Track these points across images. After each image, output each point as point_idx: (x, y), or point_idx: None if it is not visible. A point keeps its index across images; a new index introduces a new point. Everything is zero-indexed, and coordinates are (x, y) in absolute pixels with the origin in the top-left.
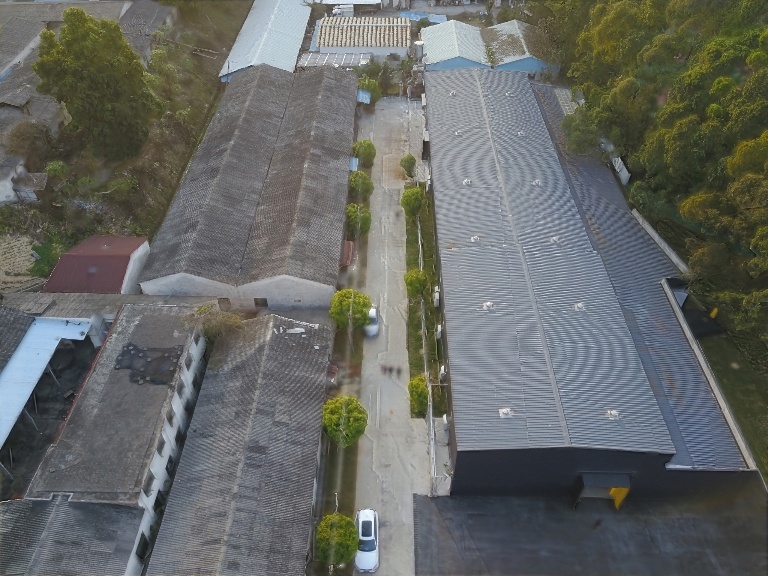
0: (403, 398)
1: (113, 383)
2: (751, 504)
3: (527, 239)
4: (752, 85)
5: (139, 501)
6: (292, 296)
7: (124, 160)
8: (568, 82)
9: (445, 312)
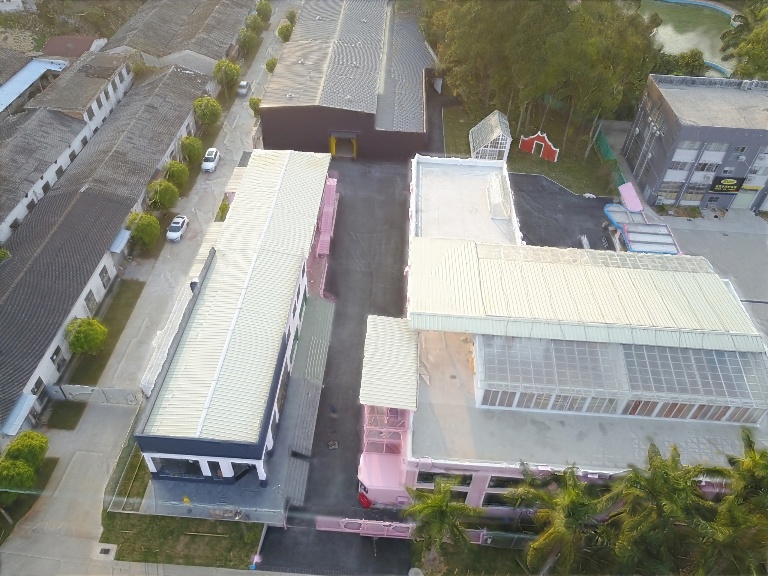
0: (252, 119)
1: (76, 76)
2: None
3: None
4: None
5: (84, 117)
6: (194, 69)
7: (97, 0)
8: None
9: None
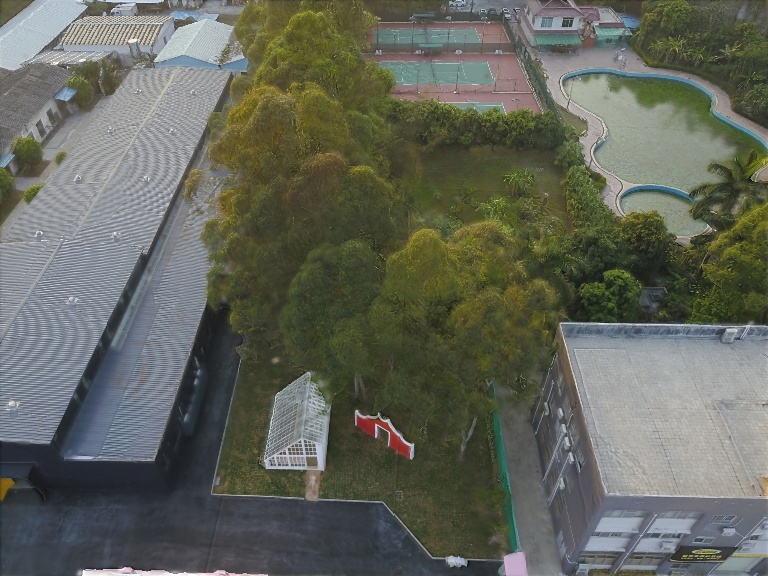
0: None
1: None
2: (188, 495)
3: (87, 234)
4: None
5: None
6: None
7: None
8: None
9: None
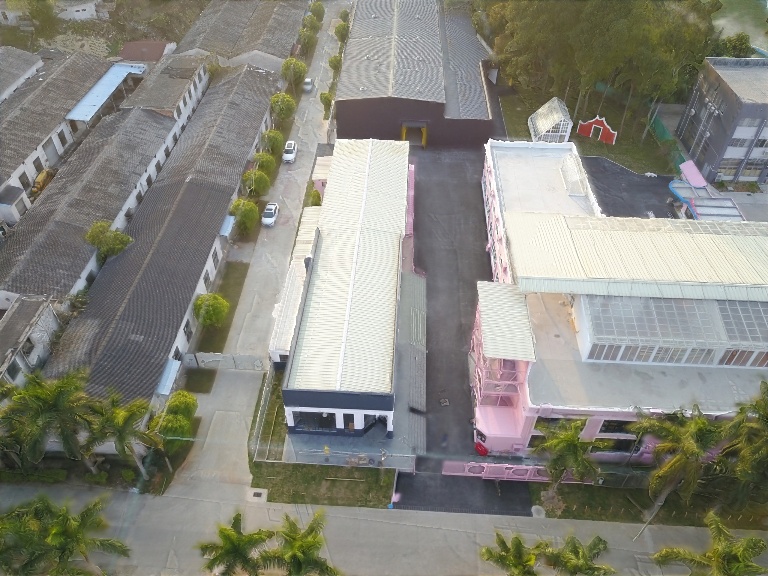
0: (320, 114)
1: (160, 78)
2: None
3: None
4: None
5: (174, 114)
6: None
7: (161, 7)
8: None
9: (343, 61)
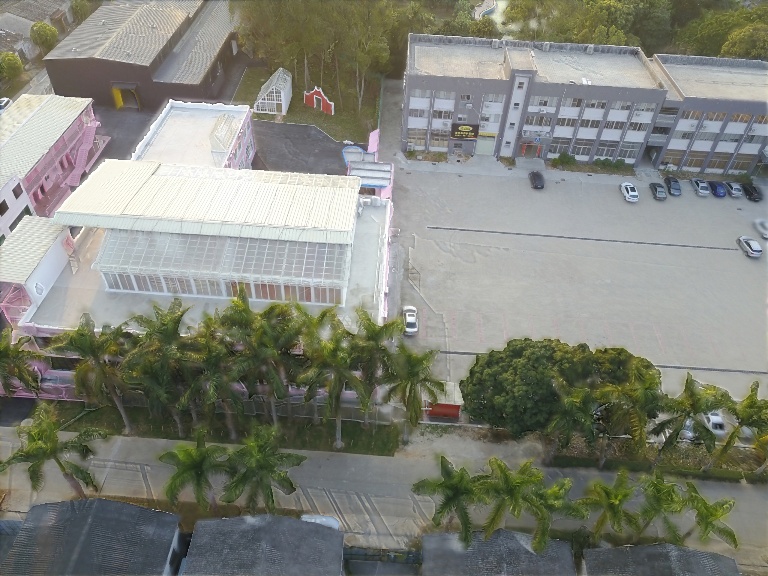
0: None
1: None
2: None
3: None
4: None
5: None
6: (17, 31)
7: None
8: None
9: None
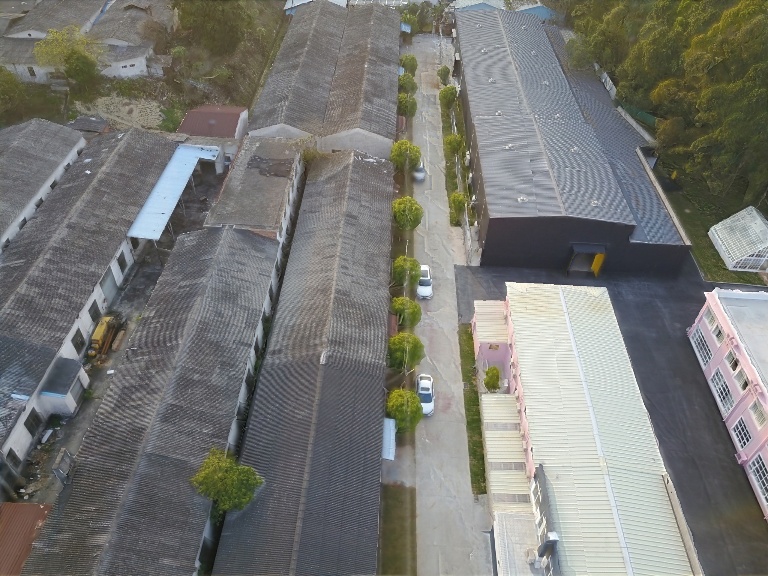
0: (444, 215)
1: (248, 175)
2: (689, 280)
3: None
4: (706, 0)
5: (277, 235)
6: (361, 149)
7: (221, 58)
8: (571, 27)
9: (478, 150)
